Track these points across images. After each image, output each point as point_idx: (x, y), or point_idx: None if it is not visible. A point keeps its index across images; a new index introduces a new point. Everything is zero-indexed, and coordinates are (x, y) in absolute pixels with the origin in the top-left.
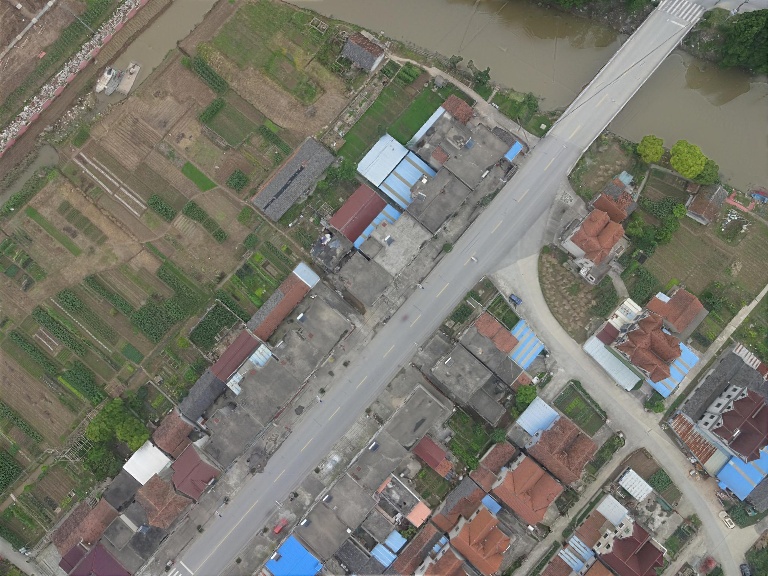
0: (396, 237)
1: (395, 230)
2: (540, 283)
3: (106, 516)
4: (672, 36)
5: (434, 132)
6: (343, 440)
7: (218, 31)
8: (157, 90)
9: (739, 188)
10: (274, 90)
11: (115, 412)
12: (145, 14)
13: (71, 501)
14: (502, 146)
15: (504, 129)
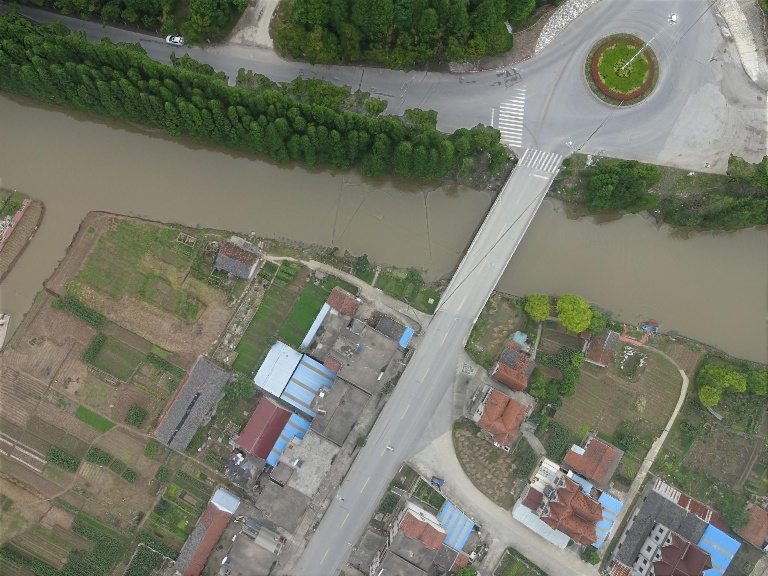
0: (305, 457)
1: (303, 450)
2: (458, 459)
3: None
4: (535, 198)
5: (324, 331)
6: None
7: (84, 264)
8: (32, 338)
9: (630, 322)
10: (154, 315)
11: None
12: (3, 261)
13: None
14: (392, 344)
15: (393, 310)
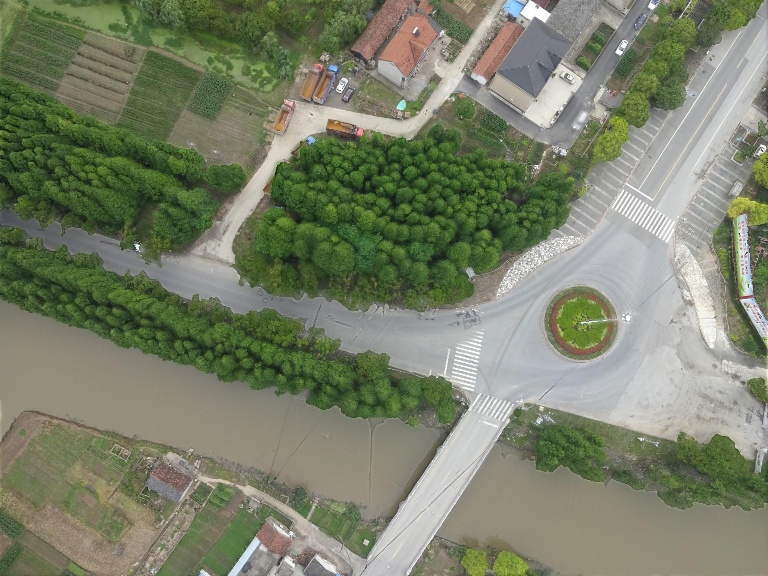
0: None
1: None
2: None
3: None
4: (481, 454)
5: (251, 567)
6: None
7: (9, 467)
8: None
9: None
10: (76, 529)
11: None
12: None
13: None
14: None
15: (326, 548)
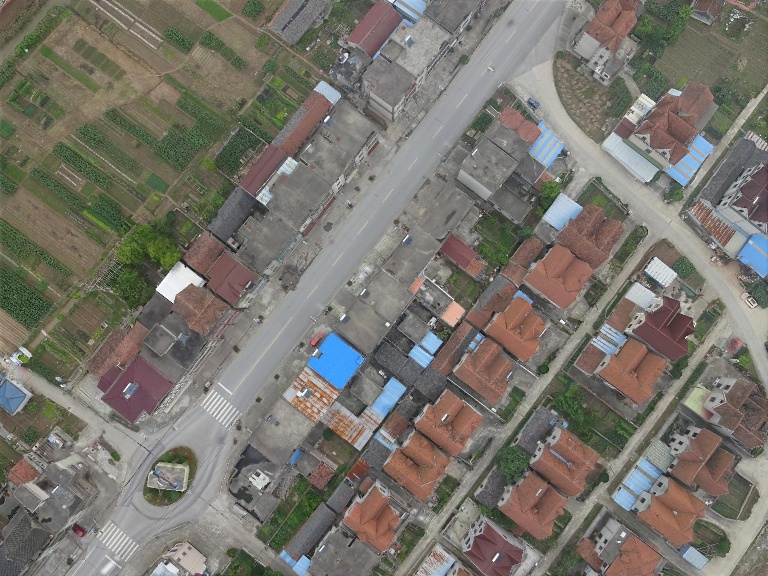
0: (416, 39)
1: (414, 32)
2: (556, 87)
3: (142, 338)
4: None
5: None
6: (373, 253)
7: None
8: None
9: None
10: None
11: (146, 231)
12: None
13: (104, 332)
14: None
15: None
